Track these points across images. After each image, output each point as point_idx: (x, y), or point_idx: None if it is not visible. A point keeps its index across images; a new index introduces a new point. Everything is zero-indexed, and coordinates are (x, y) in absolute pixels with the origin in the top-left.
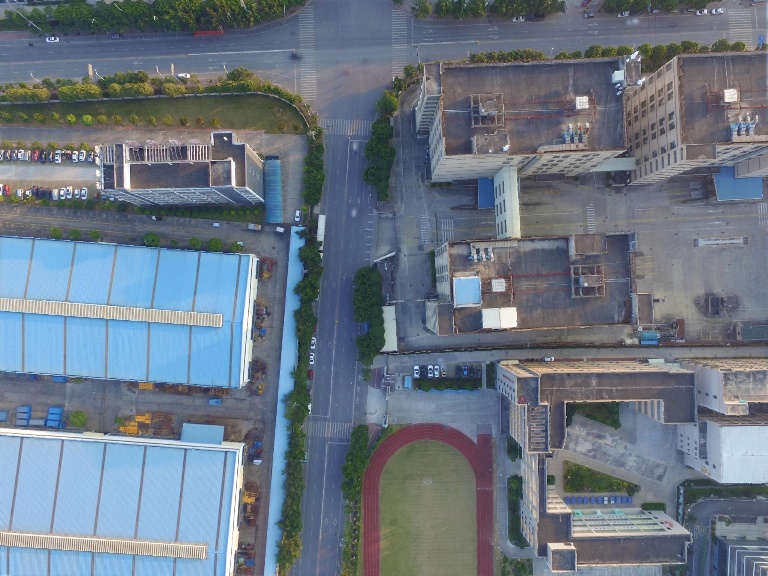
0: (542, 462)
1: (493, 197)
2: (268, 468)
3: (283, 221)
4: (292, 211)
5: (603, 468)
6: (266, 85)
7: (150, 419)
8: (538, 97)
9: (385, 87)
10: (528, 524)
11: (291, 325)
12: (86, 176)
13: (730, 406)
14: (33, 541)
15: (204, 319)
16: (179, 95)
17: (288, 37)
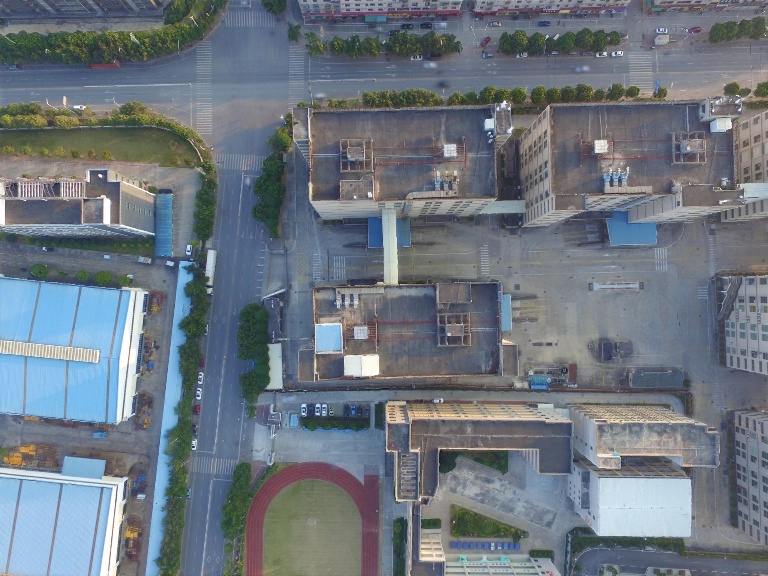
0: (417, 509)
1: (382, 237)
2: (152, 503)
3: (174, 255)
4: (184, 245)
5: (491, 513)
6: (158, 119)
7: (35, 450)
8: (409, 143)
9: (280, 123)
10: (407, 570)
11: (176, 360)
12: None
13: (602, 459)
14: None
15: (80, 354)
16: (74, 127)
17: (185, 71)
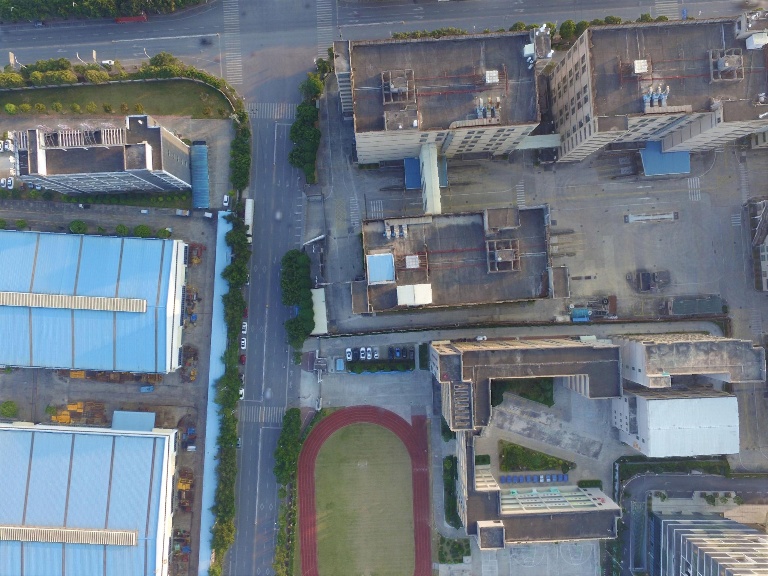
0: (470, 440)
1: (419, 177)
2: (202, 454)
3: (212, 206)
4: (221, 196)
5: (538, 446)
6: (189, 70)
7: (82, 408)
8: (450, 73)
9: (311, 70)
10: (461, 503)
11: (220, 310)
12: (12, 165)
13: (652, 379)
14: None
15: (127, 305)
16: (104, 82)
17: (213, 22)
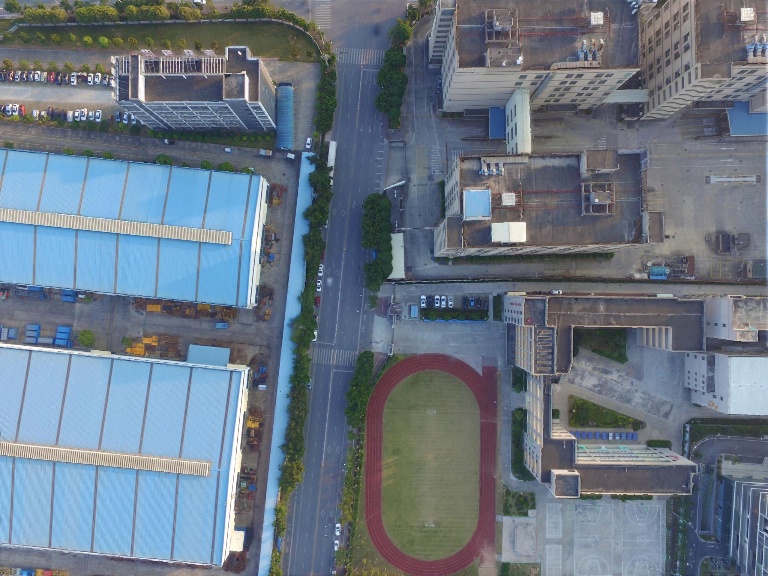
0: (547, 388)
1: (504, 126)
2: (273, 394)
3: (294, 148)
4: (303, 138)
5: (609, 404)
6: (281, 10)
7: (157, 341)
8: (553, 14)
9: (399, 17)
10: (532, 454)
11: (299, 250)
12: (101, 99)
13: (739, 332)
14: (39, 452)
15: (213, 236)
16: (194, 20)
17: None
